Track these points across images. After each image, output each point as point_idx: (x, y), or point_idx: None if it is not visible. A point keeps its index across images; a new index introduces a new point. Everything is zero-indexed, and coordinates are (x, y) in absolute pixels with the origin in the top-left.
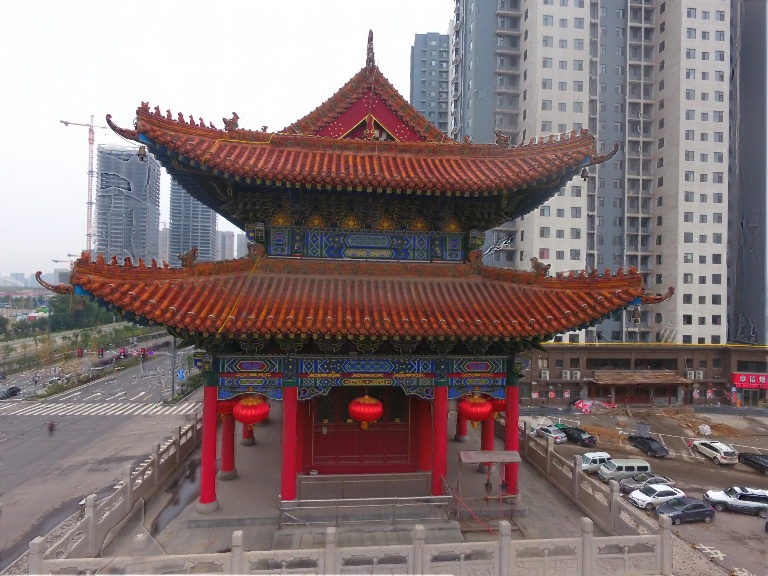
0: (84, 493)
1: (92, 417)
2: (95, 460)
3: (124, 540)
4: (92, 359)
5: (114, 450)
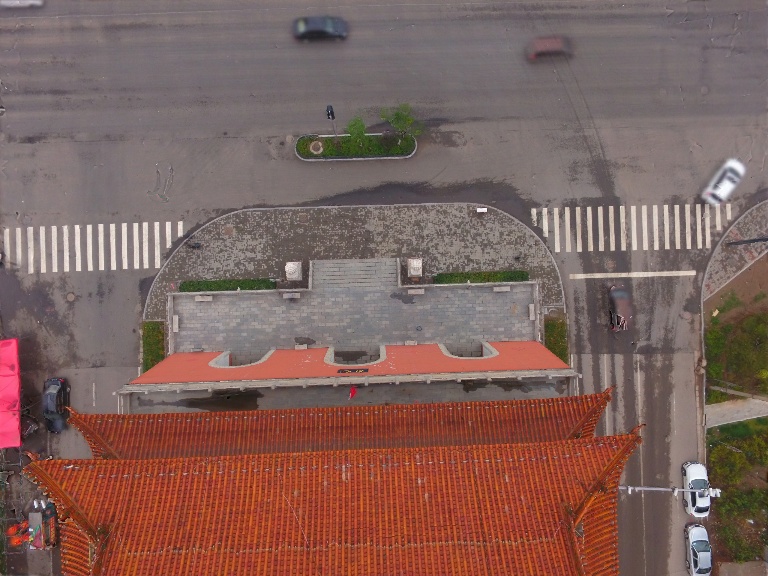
0: (520, 189)
1: (765, 59)
2: (601, 154)
3: (3, 474)
4: None
5: (631, 158)
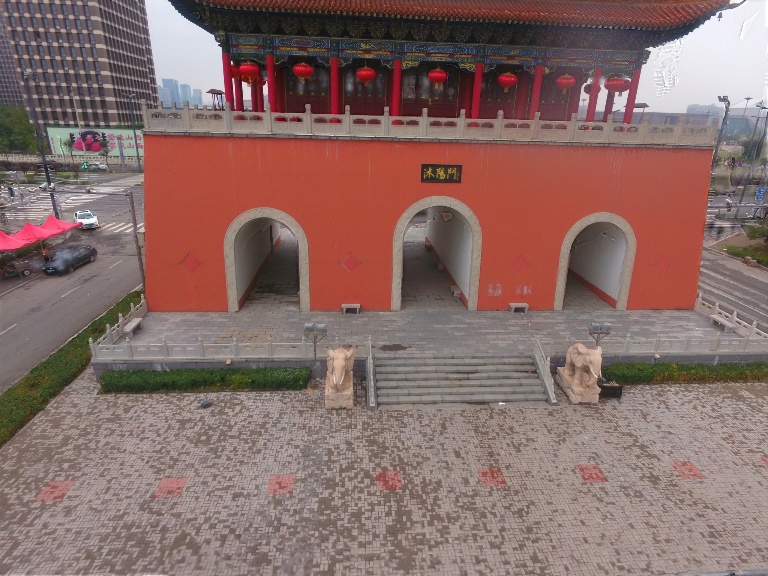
0: None
1: None
2: None
3: None
4: None
5: None
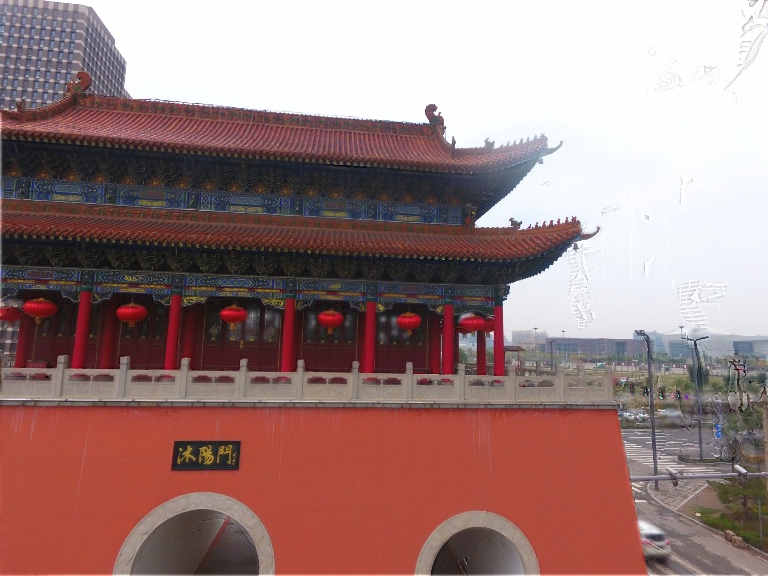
0: None
1: None
2: None
3: None
4: (641, 397)
5: None
